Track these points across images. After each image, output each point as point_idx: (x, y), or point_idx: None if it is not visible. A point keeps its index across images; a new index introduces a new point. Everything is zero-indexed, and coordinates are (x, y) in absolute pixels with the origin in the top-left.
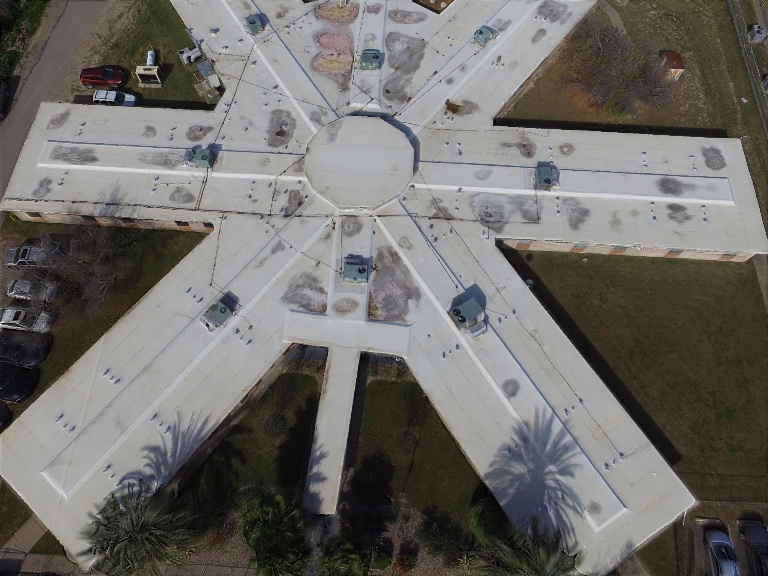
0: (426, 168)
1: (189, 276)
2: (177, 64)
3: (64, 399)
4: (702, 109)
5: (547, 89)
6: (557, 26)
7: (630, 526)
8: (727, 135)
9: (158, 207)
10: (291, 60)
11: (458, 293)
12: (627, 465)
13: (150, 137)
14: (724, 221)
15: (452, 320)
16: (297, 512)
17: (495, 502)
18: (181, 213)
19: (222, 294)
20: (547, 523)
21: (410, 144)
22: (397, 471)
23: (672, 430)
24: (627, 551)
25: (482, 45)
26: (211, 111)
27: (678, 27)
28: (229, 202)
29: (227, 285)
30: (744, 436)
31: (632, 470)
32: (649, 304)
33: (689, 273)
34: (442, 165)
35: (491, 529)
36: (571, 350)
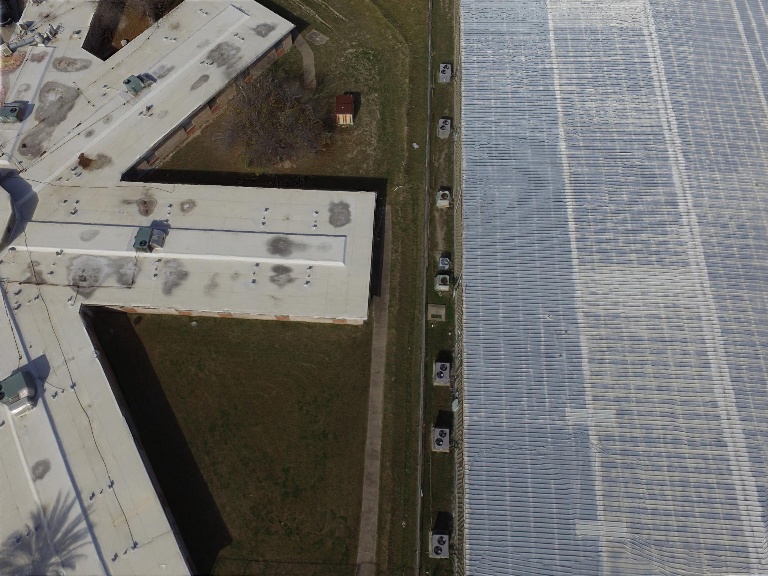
0: (32, 229)
1: None
2: None
3: None
4: (369, 156)
5: None
6: (222, 71)
7: None
8: (387, 184)
9: None
10: None
11: (20, 365)
12: (138, 556)
13: None
14: (327, 284)
15: None
16: None
17: None
18: None
19: None
20: None
21: (10, 205)
22: None
23: (230, 511)
24: None
25: (134, 94)
26: None
27: (372, 66)
28: None
29: None
30: (306, 518)
31: (141, 561)
32: (248, 372)
33: (300, 337)
34: (50, 225)
35: None
36: (120, 428)
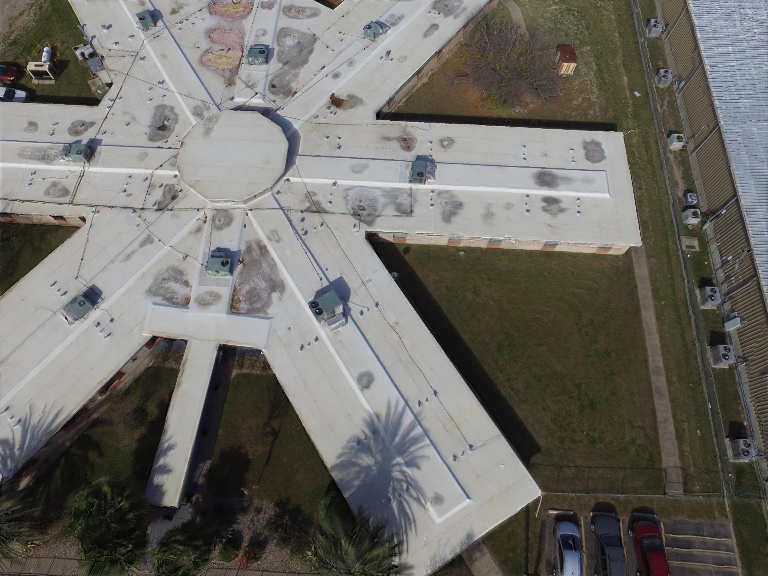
0: (303, 162)
1: (56, 270)
2: (73, 60)
3: None
4: (594, 103)
5: (441, 84)
6: (450, 21)
7: (473, 518)
8: (617, 129)
9: (31, 201)
10: (179, 55)
11: (322, 286)
12: (475, 457)
13: (31, 132)
14: (598, 214)
15: (312, 313)
16: (126, 503)
17: (340, 494)
18: (54, 207)
19: (86, 288)
20: (389, 515)
21: (285, 138)
22: (253, 464)
23: (534, 422)
24: (467, 542)
25: (372, 40)
26: (95, 106)
27: (578, 22)
28: (103, 196)
29: (92, 279)
30: (606, 428)
31: (480, 462)
32: (522, 297)
33: (565, 266)
34: (319, 159)
35: (336, 521)
36: (431, 342)
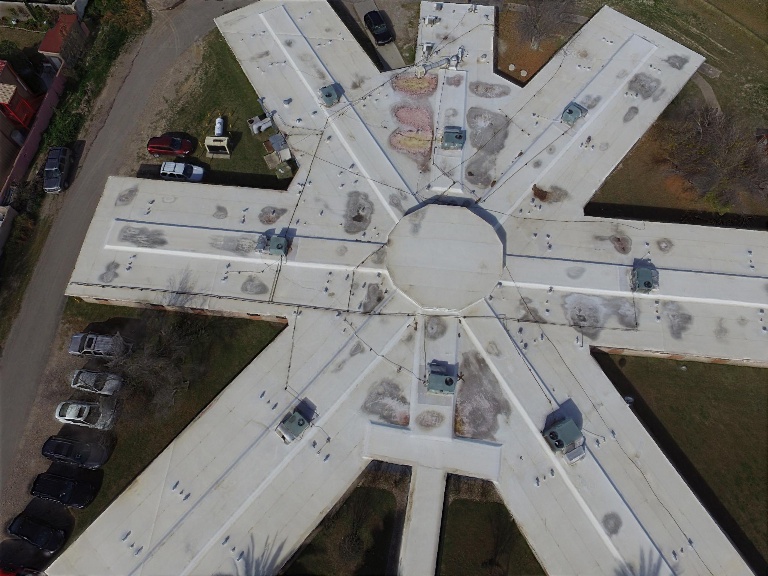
0: (514, 263)
1: (263, 378)
2: (245, 132)
3: (131, 514)
4: None
5: (636, 170)
6: (650, 104)
7: None
8: None
9: (230, 298)
10: (368, 136)
11: (552, 410)
12: None
13: (221, 218)
14: None
15: (547, 442)
16: None
17: None
18: (254, 305)
19: (298, 401)
20: None
21: (498, 238)
22: None
23: None
24: None
25: (570, 124)
26: (284, 191)
27: None
28: (304, 295)
29: (303, 390)
30: None
31: None
32: (756, 422)
33: None
34: (531, 260)
35: None
36: (677, 481)
